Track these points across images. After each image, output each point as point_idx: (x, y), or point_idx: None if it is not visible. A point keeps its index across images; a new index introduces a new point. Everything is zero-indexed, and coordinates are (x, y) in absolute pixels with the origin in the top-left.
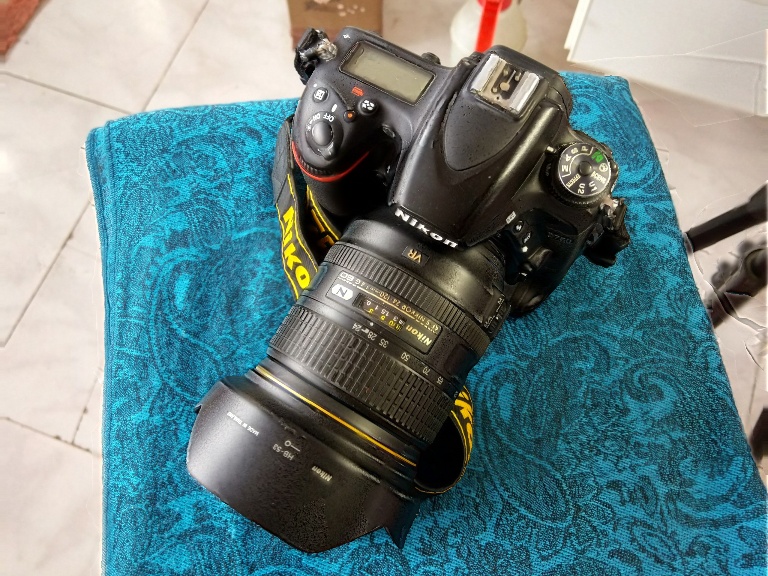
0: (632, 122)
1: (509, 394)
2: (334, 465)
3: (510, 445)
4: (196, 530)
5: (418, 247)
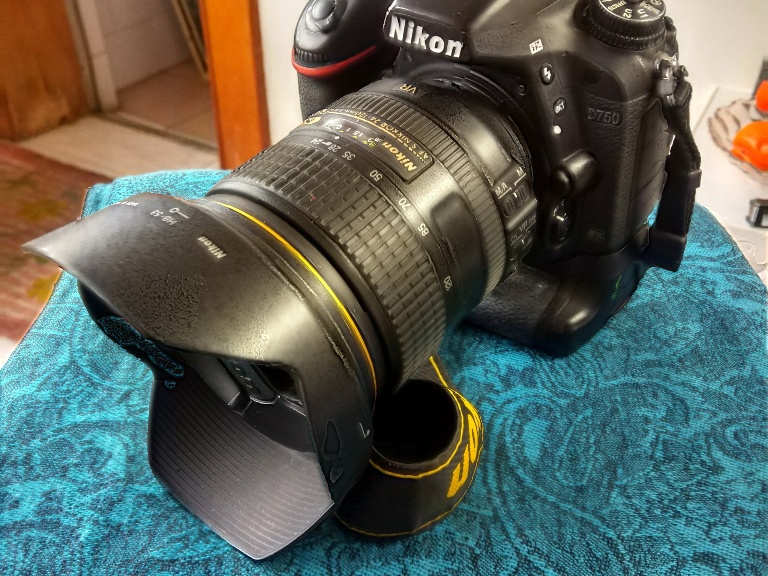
0: (703, 214)
1: (539, 431)
2: (234, 243)
3: (536, 489)
4: (31, 524)
5: (415, 84)
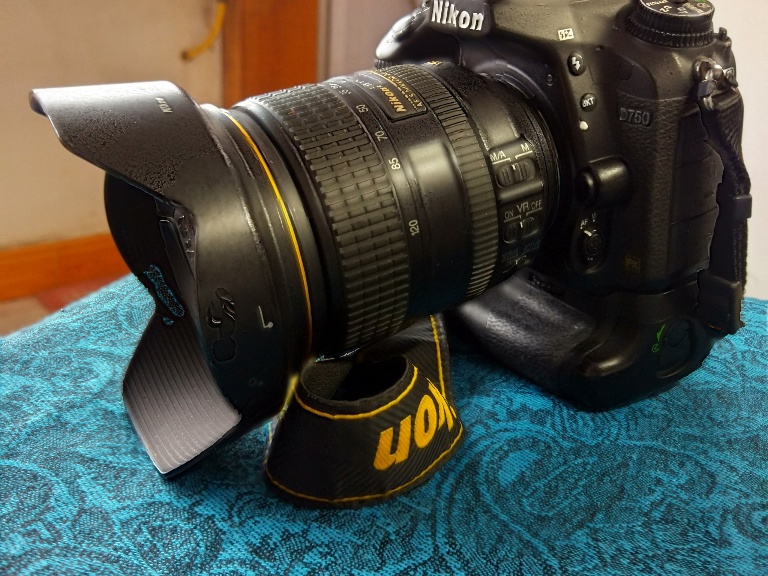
0: None
1: (525, 460)
2: (186, 108)
3: (492, 505)
4: None
5: None
